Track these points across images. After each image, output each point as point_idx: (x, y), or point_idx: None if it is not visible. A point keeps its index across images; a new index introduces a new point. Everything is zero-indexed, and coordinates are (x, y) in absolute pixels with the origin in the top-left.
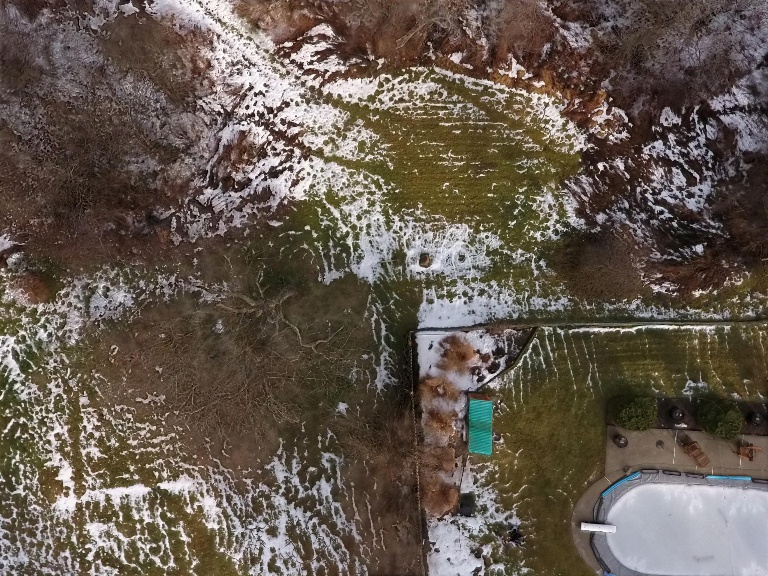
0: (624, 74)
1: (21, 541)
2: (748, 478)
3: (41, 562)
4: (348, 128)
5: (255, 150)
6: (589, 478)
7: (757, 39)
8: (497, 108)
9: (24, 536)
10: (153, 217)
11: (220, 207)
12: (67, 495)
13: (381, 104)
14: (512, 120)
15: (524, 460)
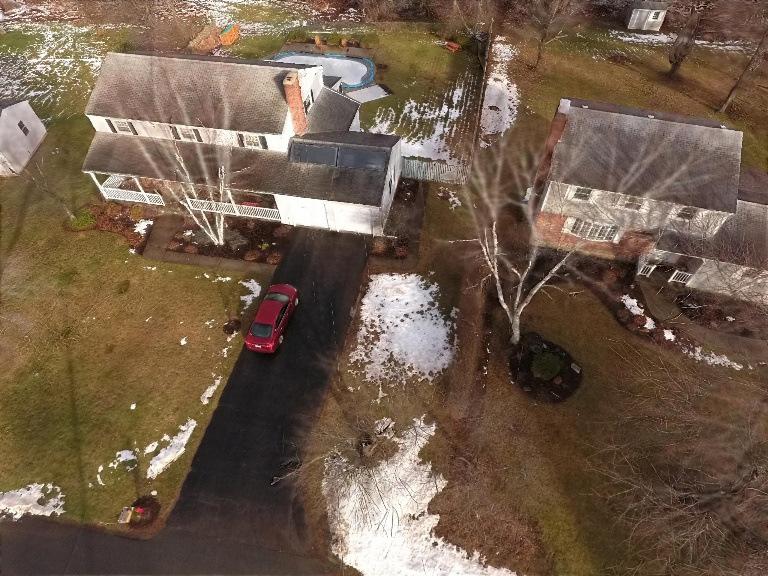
0: (338, 3)
1: (4, 67)
2: (344, 56)
3: (6, 72)
4: (227, 6)
5: (188, 6)
6: (271, 53)
7: (391, 0)
8: (286, 6)
9: (7, 66)
10: (138, 14)
11: (166, 15)
12: (38, 59)
13: (243, 3)
14: (291, 8)
15: (245, 48)
